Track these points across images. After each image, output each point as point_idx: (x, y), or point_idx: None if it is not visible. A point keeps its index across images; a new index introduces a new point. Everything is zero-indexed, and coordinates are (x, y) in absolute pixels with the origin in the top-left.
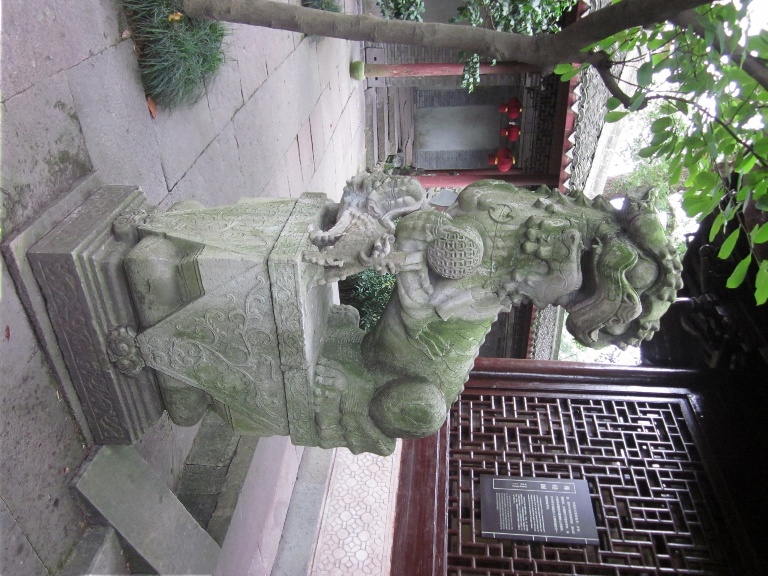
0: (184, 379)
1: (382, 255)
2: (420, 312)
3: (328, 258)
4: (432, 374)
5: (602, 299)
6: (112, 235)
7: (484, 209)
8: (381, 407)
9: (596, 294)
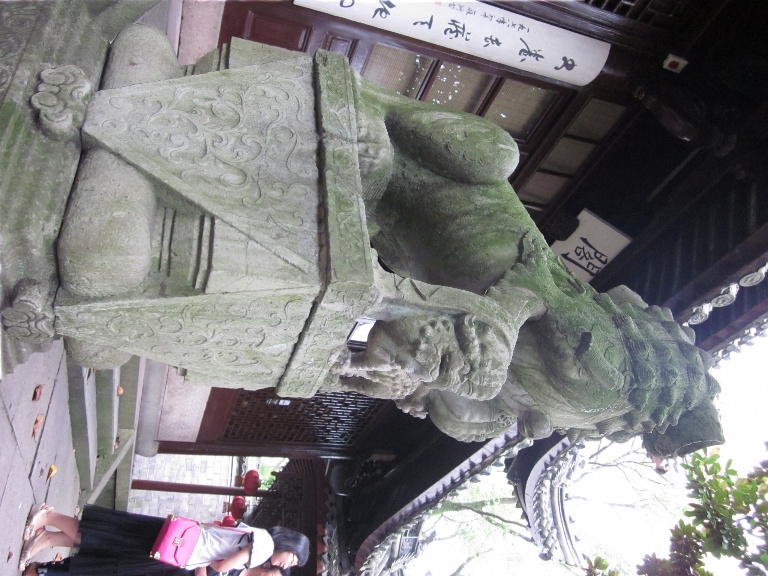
0: None
1: None
2: None
3: None
4: None
5: None
6: None
7: None
8: None
9: None
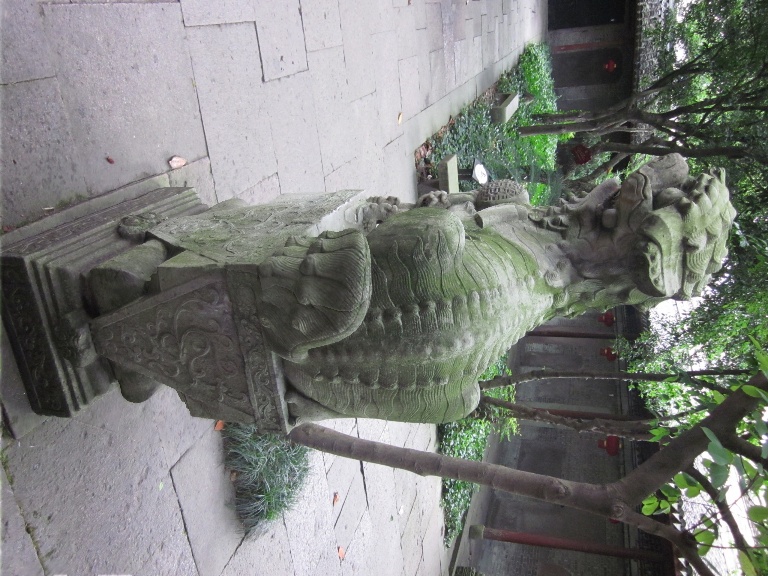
0: (168, 238)
1: None
2: None
3: None
4: None
5: None
6: None
7: None
8: None
9: None
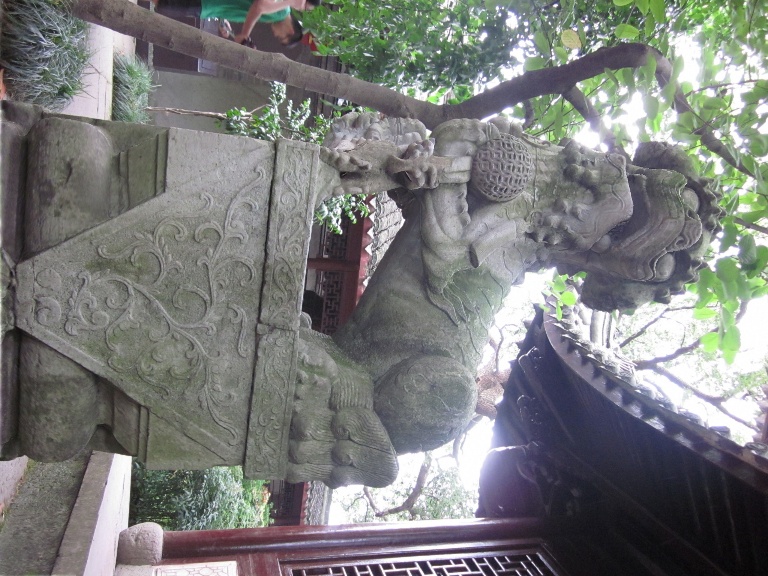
0: (81, 356)
1: (426, 154)
2: (452, 250)
3: (353, 156)
4: (455, 348)
5: (662, 221)
6: (2, 109)
7: (517, 135)
8: (398, 389)
9: (648, 222)
